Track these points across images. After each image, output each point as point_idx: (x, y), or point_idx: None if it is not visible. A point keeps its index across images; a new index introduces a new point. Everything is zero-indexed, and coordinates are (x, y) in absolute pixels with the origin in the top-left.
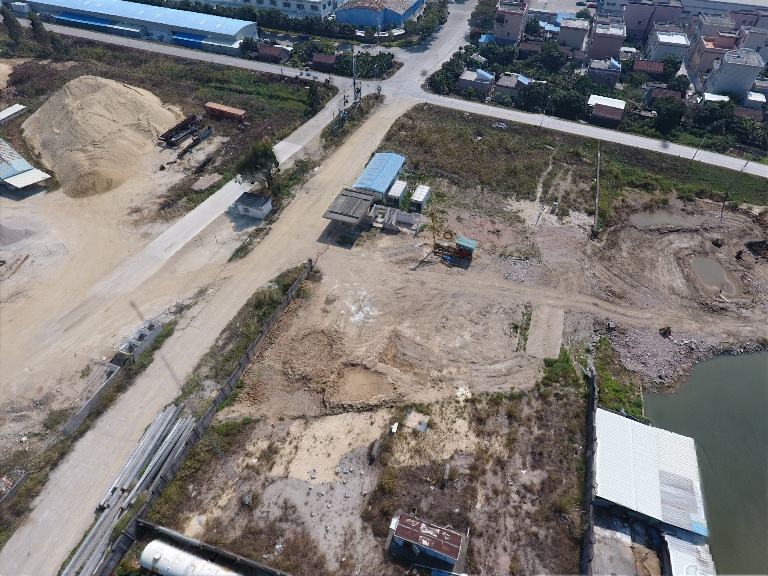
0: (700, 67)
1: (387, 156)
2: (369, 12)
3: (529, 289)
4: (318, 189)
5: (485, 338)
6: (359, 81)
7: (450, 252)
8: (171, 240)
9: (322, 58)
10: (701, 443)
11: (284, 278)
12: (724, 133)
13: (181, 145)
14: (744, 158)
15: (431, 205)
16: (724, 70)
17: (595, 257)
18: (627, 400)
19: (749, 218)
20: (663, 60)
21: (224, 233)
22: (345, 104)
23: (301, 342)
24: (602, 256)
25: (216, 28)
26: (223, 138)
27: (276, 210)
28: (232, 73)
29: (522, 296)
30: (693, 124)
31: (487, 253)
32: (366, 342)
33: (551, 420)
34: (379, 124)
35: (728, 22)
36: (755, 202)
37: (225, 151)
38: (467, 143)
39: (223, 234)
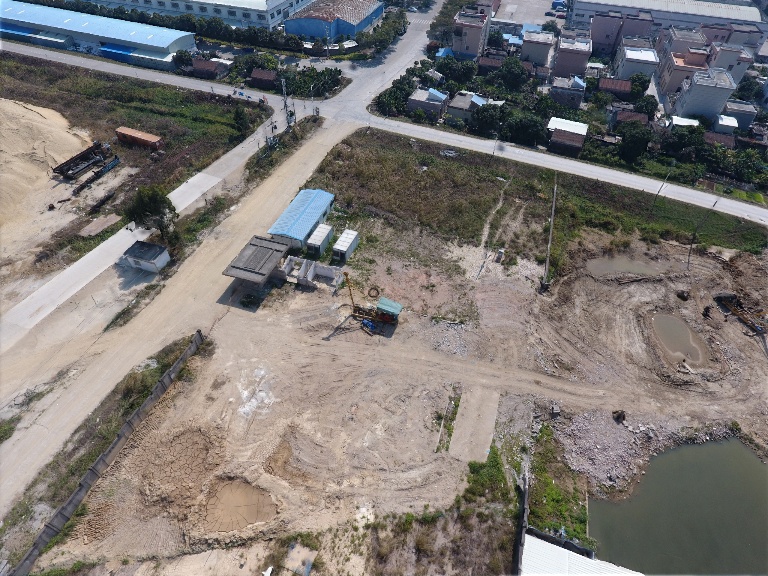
0: (670, 86)
1: (313, 194)
2: (320, 22)
3: (461, 364)
4: (230, 233)
5: (401, 433)
6: (297, 101)
7: (372, 316)
8: (41, 302)
9: (261, 74)
10: (656, 572)
11: (166, 354)
12: (694, 161)
13: (80, 178)
14: (714, 190)
15: (359, 253)
16: (693, 92)
17: (543, 316)
18: (569, 513)
19: (719, 264)
20: (630, 78)
21: (107, 292)
22: (279, 128)
23: (170, 446)
24: (551, 315)
25: (147, 39)
26: (132, 169)
27: (176, 261)
28: (157, 91)
29: (451, 374)
30: (660, 151)
31: (416, 316)
32: (253, 443)
33: (470, 553)
34: (314, 152)
35: (699, 37)
36: (725, 245)
37: (130, 186)
38: (409, 175)
39: (106, 293)
